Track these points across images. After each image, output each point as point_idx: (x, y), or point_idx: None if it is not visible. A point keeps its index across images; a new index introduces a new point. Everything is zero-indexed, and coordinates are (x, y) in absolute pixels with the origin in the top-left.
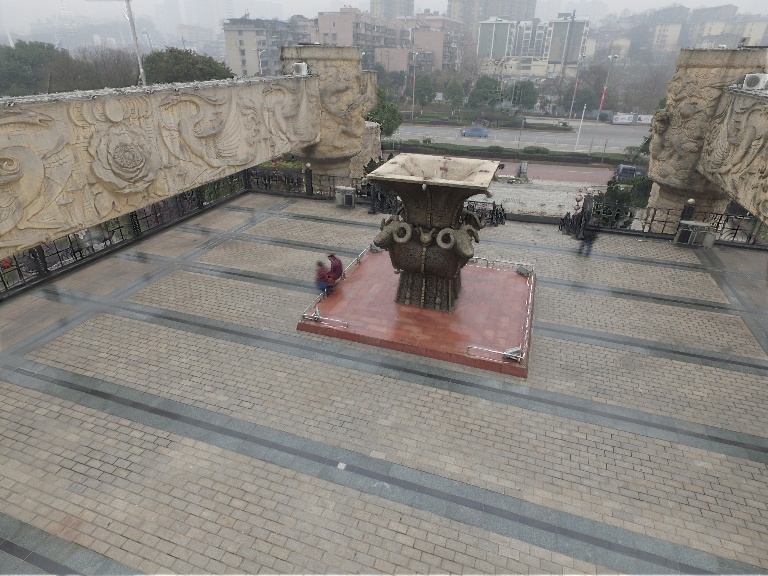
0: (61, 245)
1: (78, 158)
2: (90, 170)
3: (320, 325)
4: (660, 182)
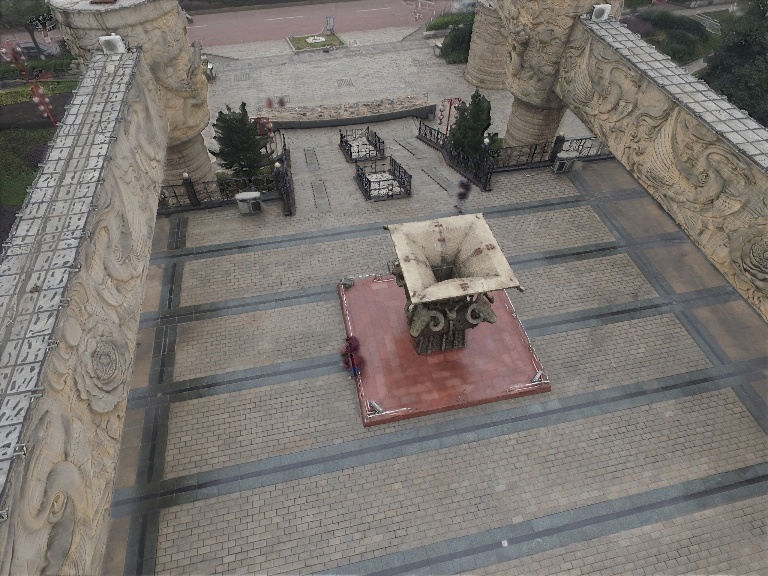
0: None
1: (79, 416)
2: (91, 413)
3: (385, 417)
4: (522, 100)
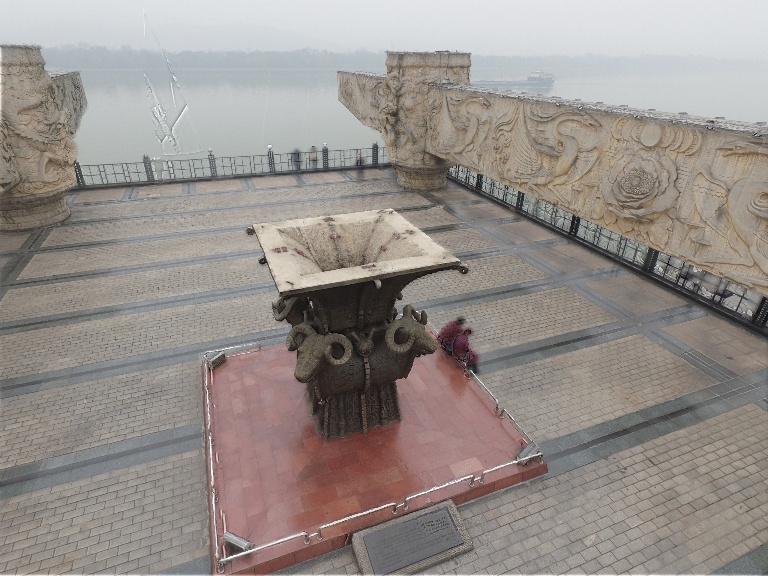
0: (675, 261)
1: (602, 163)
2: None
3: None
4: None
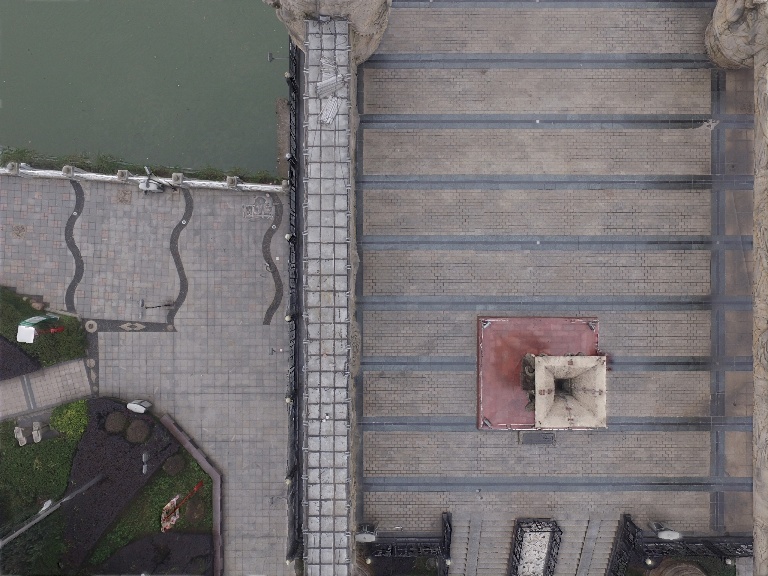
0: None
1: None
2: None
3: None
4: None
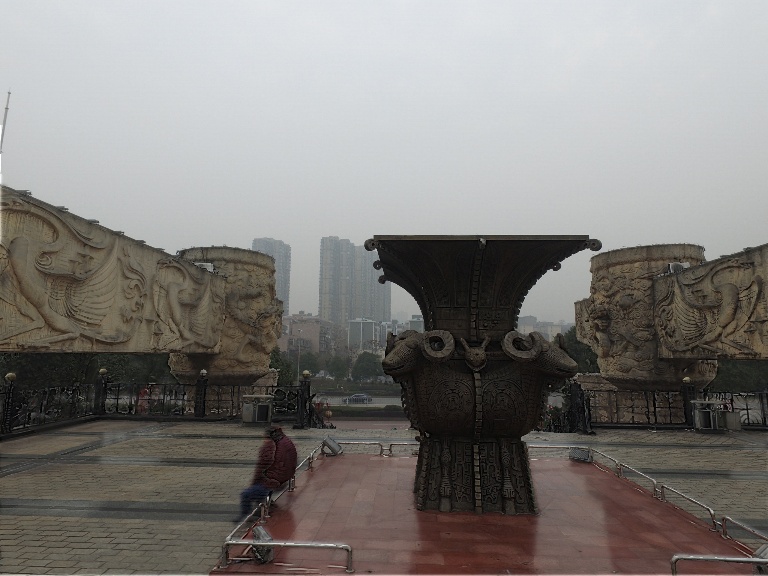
0: None
1: None
2: None
3: (273, 570)
4: (624, 378)
